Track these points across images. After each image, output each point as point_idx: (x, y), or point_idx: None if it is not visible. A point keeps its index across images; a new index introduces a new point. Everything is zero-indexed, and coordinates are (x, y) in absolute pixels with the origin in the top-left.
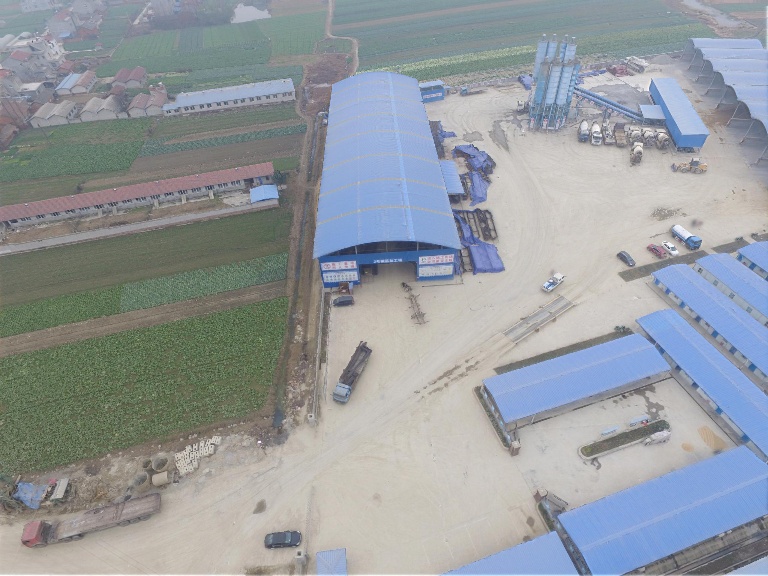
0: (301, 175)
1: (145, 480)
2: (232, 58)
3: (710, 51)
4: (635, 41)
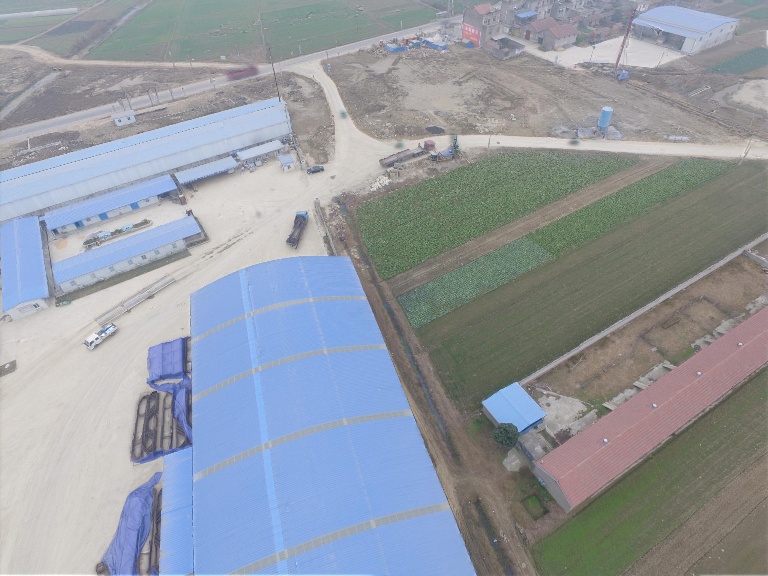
0: (505, 520)
1: (395, 165)
2: None
3: None
4: None
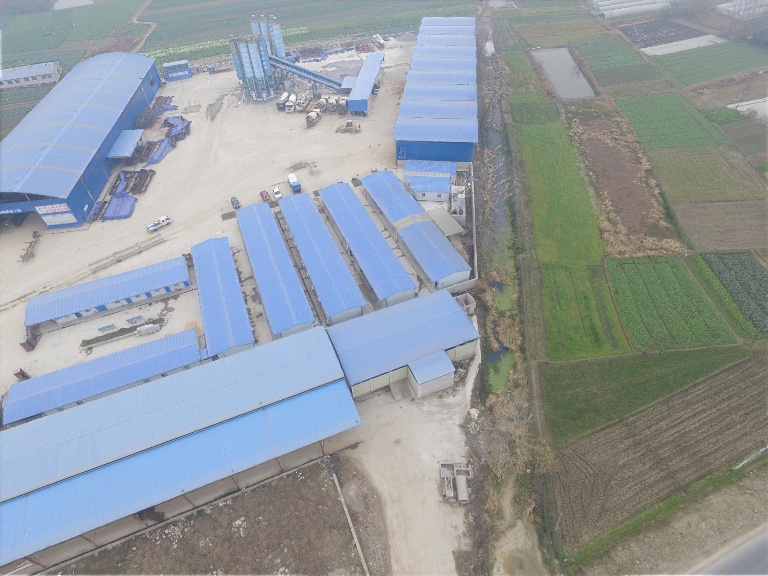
0: None
1: None
2: (24, 44)
3: (426, 28)
4: (400, 21)
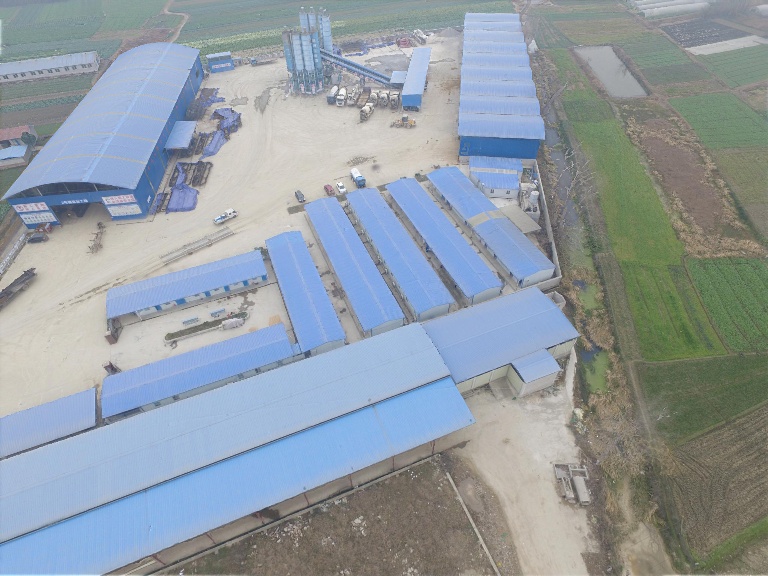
0: None
1: None
2: (57, 33)
3: (471, 24)
4: (438, 16)
